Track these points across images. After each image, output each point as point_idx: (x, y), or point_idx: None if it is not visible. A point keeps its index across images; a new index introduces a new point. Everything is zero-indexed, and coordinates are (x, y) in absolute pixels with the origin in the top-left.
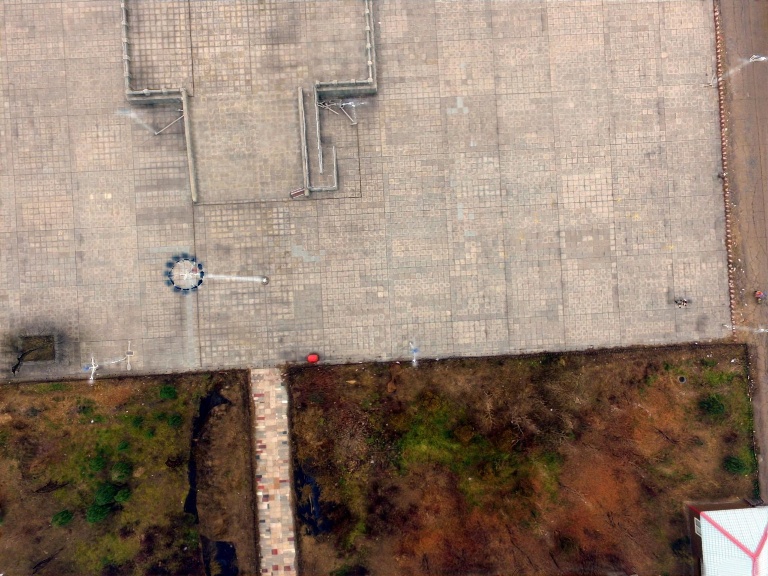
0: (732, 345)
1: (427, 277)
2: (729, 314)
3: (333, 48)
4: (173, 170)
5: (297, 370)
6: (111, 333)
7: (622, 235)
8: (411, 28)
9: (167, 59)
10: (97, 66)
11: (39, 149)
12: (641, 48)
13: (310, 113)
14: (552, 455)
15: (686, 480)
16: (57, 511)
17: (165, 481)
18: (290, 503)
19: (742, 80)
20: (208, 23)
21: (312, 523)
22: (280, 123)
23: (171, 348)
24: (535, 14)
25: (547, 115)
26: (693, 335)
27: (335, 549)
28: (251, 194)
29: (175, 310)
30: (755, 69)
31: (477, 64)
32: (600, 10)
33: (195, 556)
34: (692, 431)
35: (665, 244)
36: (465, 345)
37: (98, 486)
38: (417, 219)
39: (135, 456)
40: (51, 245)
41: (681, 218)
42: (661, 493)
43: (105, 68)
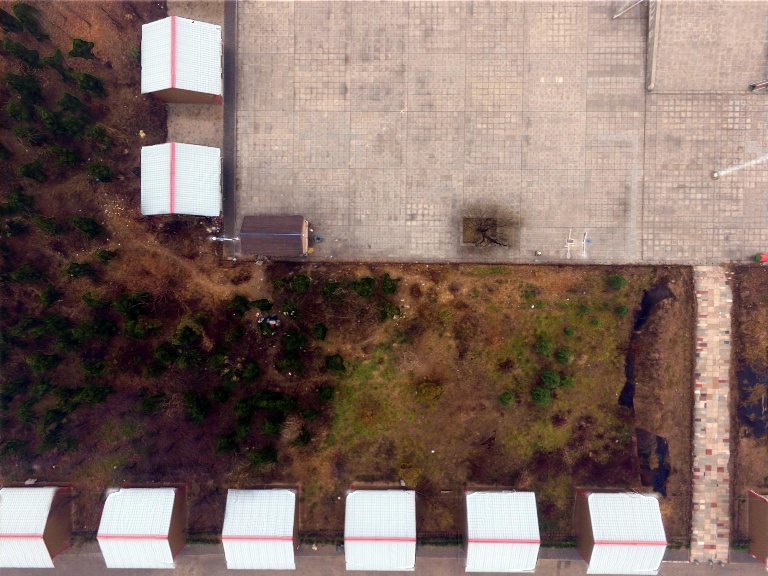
0: None
1: None
2: None
3: None
4: (628, 56)
5: (743, 269)
6: (553, 220)
7: None
8: None
9: None
10: None
11: (493, 28)
12: None
13: None
14: None
15: None
16: (491, 393)
17: (601, 372)
18: (728, 404)
19: None
20: None
21: (758, 425)
22: (751, 10)
23: (613, 239)
24: None
25: None
26: None
27: None
28: (708, 85)
29: (619, 200)
30: None
31: None
32: None
33: (627, 449)
34: None
35: None
36: None
37: (534, 372)
38: None
39: (573, 344)
40: (498, 127)
41: None
42: None
43: None
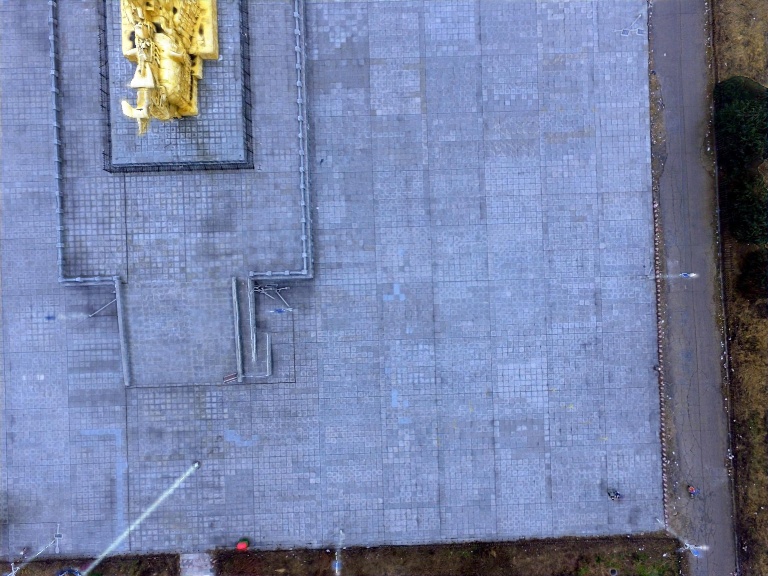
0: (664, 539)
1: (360, 464)
2: (662, 507)
3: (269, 237)
4: (107, 352)
5: (226, 556)
6: (40, 515)
7: (556, 425)
8: (349, 214)
9: (102, 245)
10: (33, 247)
11: None
12: (579, 238)
13: (244, 301)
14: None
15: None
16: None
17: None
18: None
19: (680, 272)
20: (144, 210)
21: None
22: (214, 310)
23: (100, 531)
24: (474, 202)
25: (484, 304)
26: (625, 528)
27: None
28: (184, 378)
29: (105, 493)
30: (693, 262)
31: (414, 251)
32: (539, 199)
33: None
34: None
35: (599, 435)
36: (396, 533)
37: None
38: (351, 406)
39: None
40: None
41: (616, 410)
42: None
43: (41, 249)
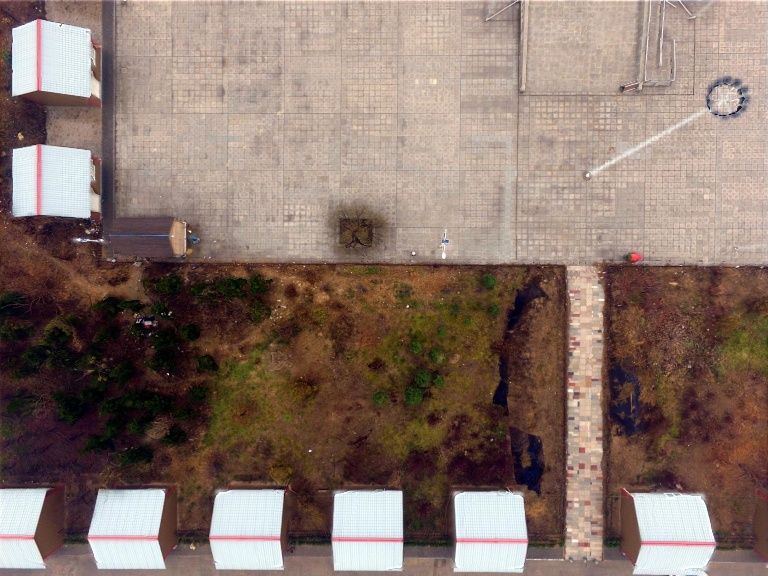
0: None
1: (757, 181)
2: None
3: None
4: (501, 58)
5: (615, 269)
6: (428, 220)
7: None
8: None
9: None
10: None
11: (368, 31)
12: None
13: (652, 3)
14: None
15: None
16: (367, 393)
17: (476, 371)
18: (601, 403)
19: None
20: None
21: (628, 423)
22: (619, 12)
23: (487, 239)
24: None
25: None
26: None
27: (645, 452)
28: (579, 86)
29: (493, 201)
30: None
31: None
32: None
33: (502, 448)
34: None
35: None
36: None
37: (409, 371)
38: (751, 120)
39: (448, 344)
40: (373, 128)
41: None
42: None
43: None
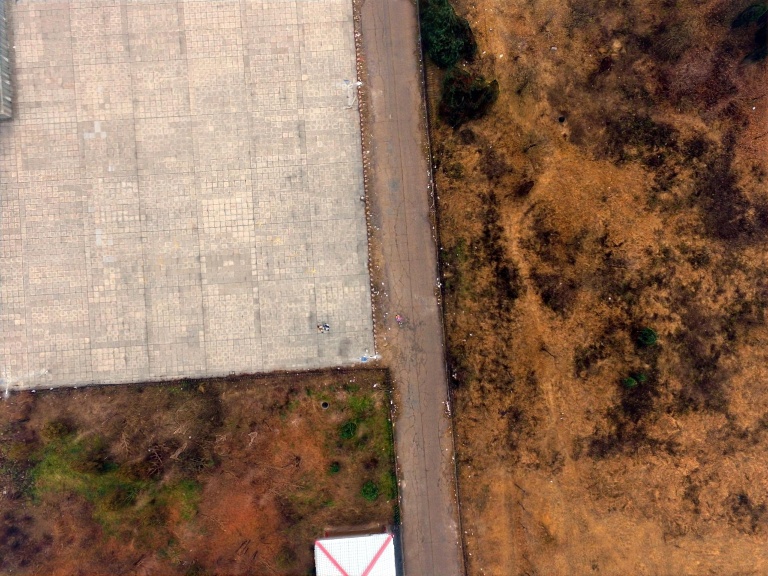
0: (374, 370)
1: (65, 304)
2: (372, 338)
3: None
4: None
5: None
6: None
7: (263, 260)
8: (47, 52)
9: None
10: None
11: None
12: (281, 71)
13: None
14: (190, 483)
15: (326, 507)
16: None
17: None
18: None
19: (384, 102)
20: None
21: None
22: None
23: None
24: (173, 37)
25: (186, 139)
26: (336, 360)
27: None
28: None
29: None
30: (397, 91)
31: (115, 88)
32: (239, 33)
33: None
34: (333, 457)
35: (307, 268)
36: (104, 373)
37: None
38: (54, 245)
39: None
40: None
41: (323, 242)
42: (301, 520)
43: None
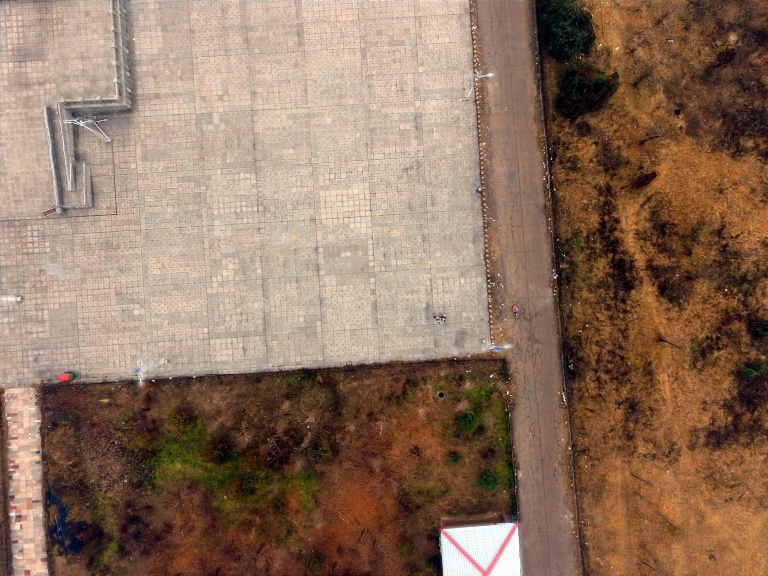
0: (490, 360)
1: (184, 294)
2: (488, 329)
3: (81, 65)
4: None
5: (51, 389)
6: None
7: (380, 251)
8: (166, 44)
9: None
10: None
11: None
12: (398, 63)
13: None
14: (309, 473)
15: (443, 496)
16: None
17: None
18: (43, 523)
19: (500, 94)
20: None
21: (61, 544)
22: (30, 141)
23: None
24: (291, 29)
25: (304, 131)
26: (452, 350)
27: (88, 569)
28: (5, 212)
29: None
30: (513, 83)
31: (233, 80)
32: (357, 25)
33: None
34: (450, 447)
35: (424, 259)
36: (223, 362)
37: None
38: (173, 236)
39: None
40: None
41: (439, 233)
42: (419, 510)
43: None
